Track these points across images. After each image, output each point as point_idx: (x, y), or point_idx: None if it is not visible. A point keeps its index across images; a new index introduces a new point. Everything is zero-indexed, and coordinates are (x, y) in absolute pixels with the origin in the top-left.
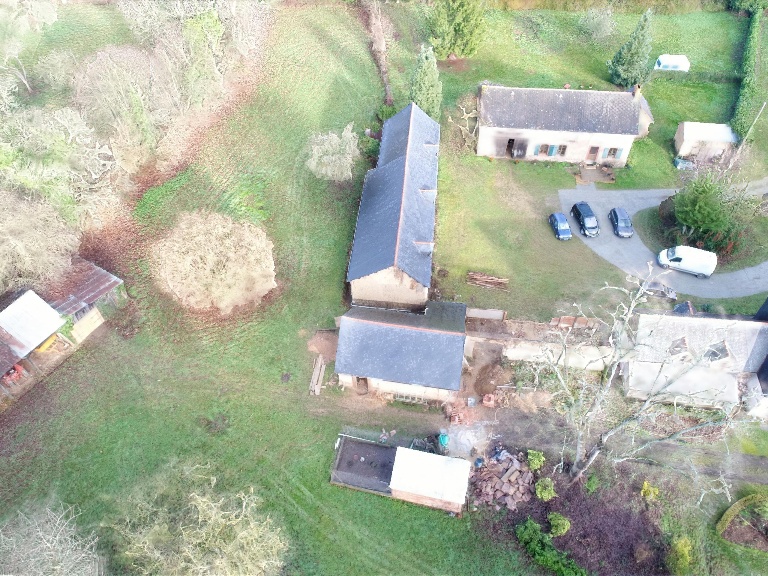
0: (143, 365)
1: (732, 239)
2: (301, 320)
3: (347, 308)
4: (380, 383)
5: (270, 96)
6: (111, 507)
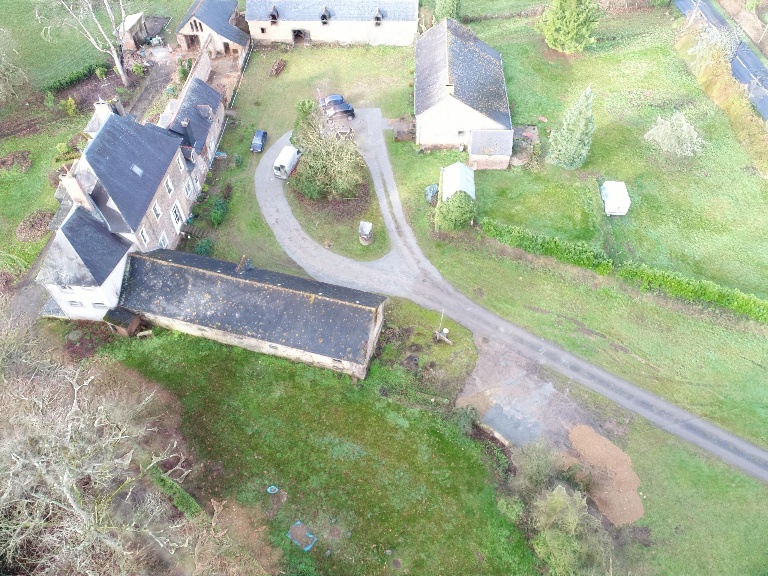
0: None
1: None
2: None
3: None
4: None
5: None
6: None
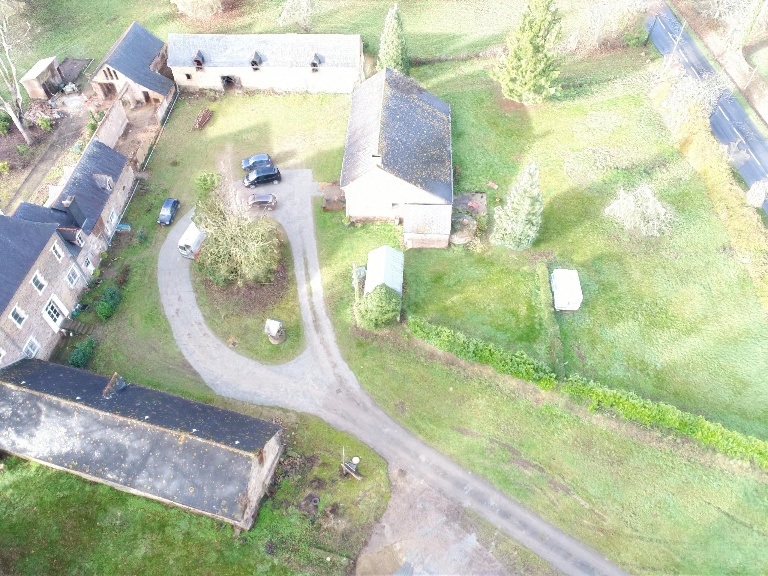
0: None
1: None
2: None
3: None
4: None
5: (422, 3)
6: (79, 0)
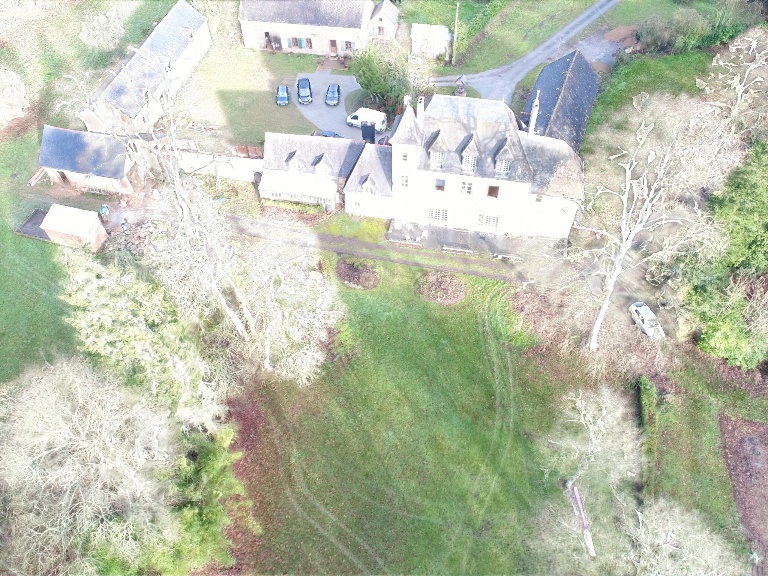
0: None
1: (401, 103)
2: None
3: None
4: (74, 177)
5: (95, 1)
6: None
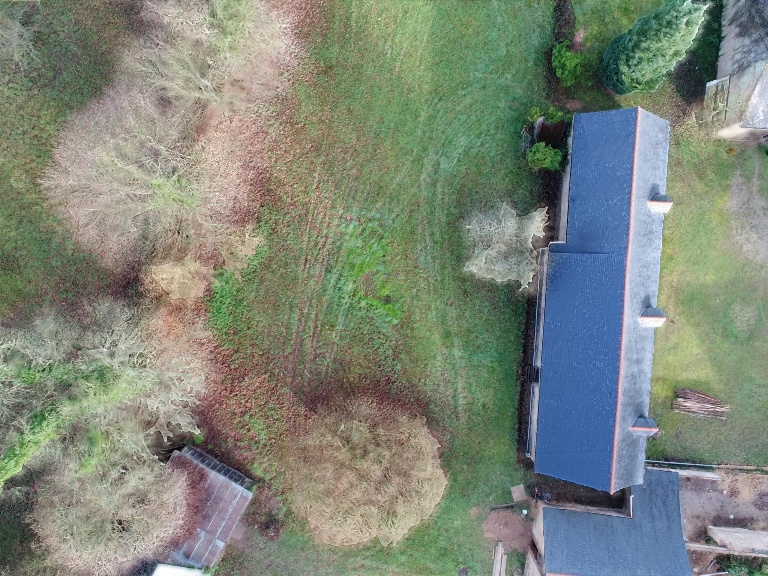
0: (303, 572)
1: None
2: (470, 493)
3: (525, 471)
4: None
5: (351, 3)
6: None
